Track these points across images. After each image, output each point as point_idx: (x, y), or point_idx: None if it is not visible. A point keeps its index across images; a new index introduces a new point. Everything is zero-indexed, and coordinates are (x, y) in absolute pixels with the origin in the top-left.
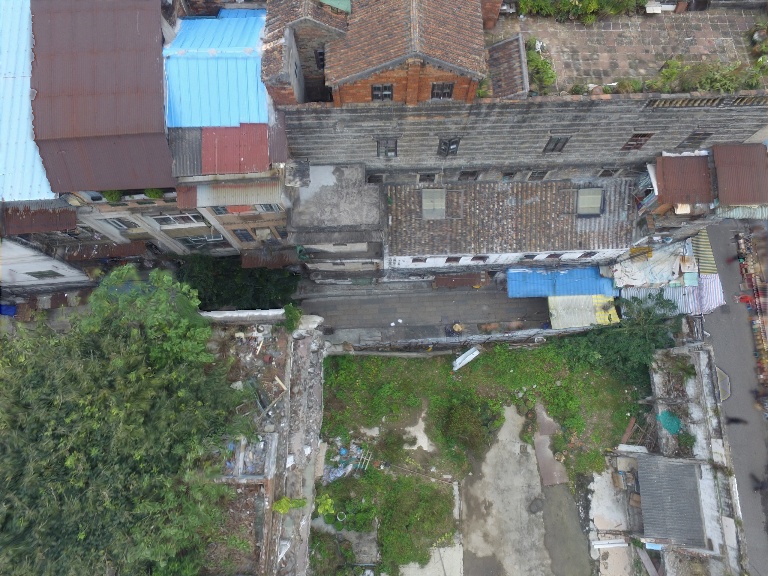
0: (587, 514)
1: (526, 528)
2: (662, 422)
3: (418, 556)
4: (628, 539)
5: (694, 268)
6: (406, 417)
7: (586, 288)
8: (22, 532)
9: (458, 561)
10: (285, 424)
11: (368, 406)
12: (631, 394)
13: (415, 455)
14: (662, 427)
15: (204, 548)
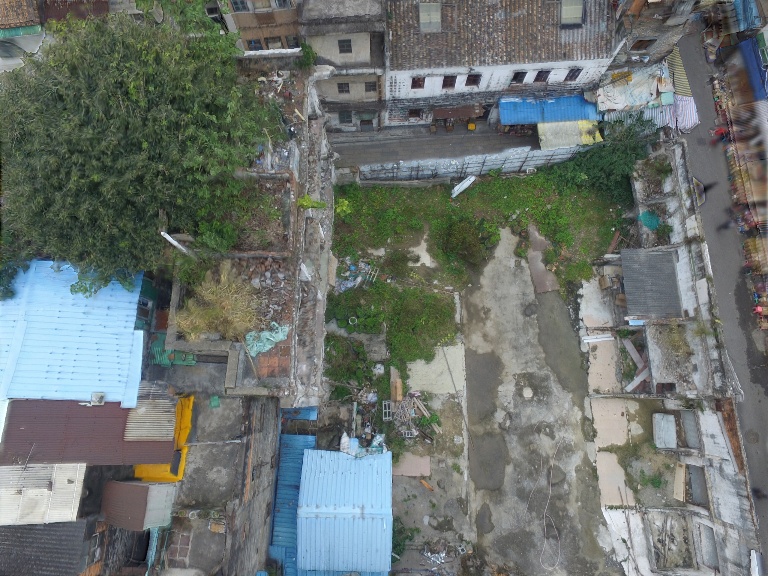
0: (577, 315)
1: (522, 328)
2: (643, 221)
3: (424, 354)
4: (614, 333)
5: (670, 89)
6: (409, 239)
7: (572, 114)
8: (97, 133)
9: (460, 357)
10: (305, 146)
11: (374, 229)
12: (615, 212)
13: (419, 271)
14: (643, 225)
15: (240, 233)
